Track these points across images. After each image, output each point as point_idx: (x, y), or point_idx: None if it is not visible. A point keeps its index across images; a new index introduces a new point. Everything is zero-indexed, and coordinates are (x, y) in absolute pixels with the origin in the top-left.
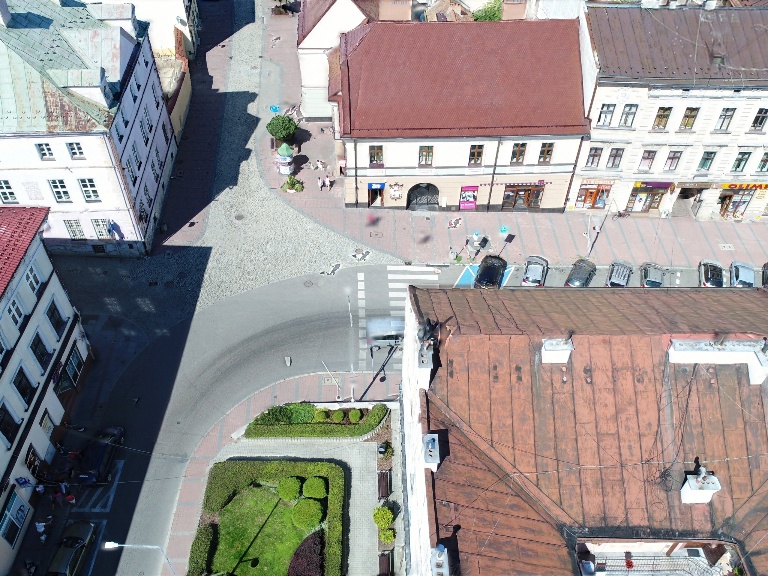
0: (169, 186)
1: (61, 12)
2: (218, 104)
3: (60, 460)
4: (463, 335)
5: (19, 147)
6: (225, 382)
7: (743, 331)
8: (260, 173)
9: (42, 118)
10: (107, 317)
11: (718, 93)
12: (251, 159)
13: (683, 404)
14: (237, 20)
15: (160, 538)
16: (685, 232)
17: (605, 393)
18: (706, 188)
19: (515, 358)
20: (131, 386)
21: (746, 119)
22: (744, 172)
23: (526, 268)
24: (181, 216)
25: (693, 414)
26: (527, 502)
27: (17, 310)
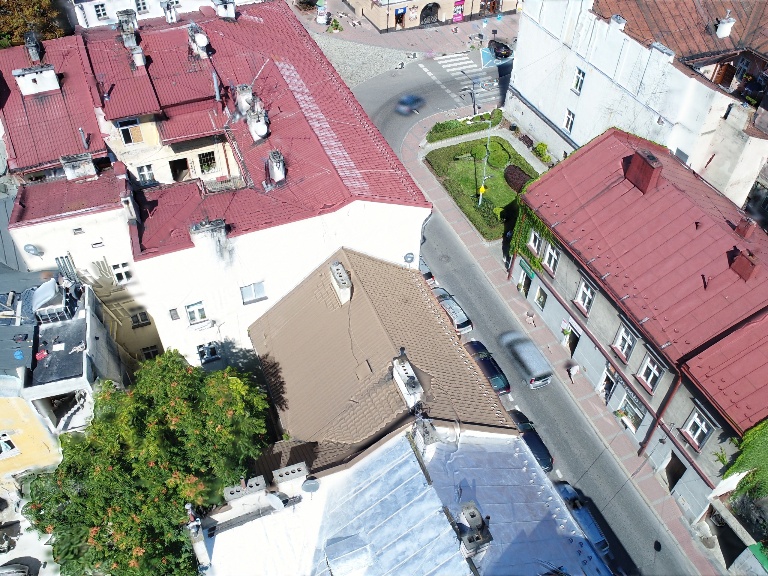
0: None
1: None
2: None
3: None
4: None
5: None
6: (388, 128)
7: None
8: None
9: None
10: None
11: None
12: None
13: None
14: None
15: None
16: None
17: None
18: None
19: None
20: None
21: None
22: None
23: None
24: None
25: None
26: None
27: None
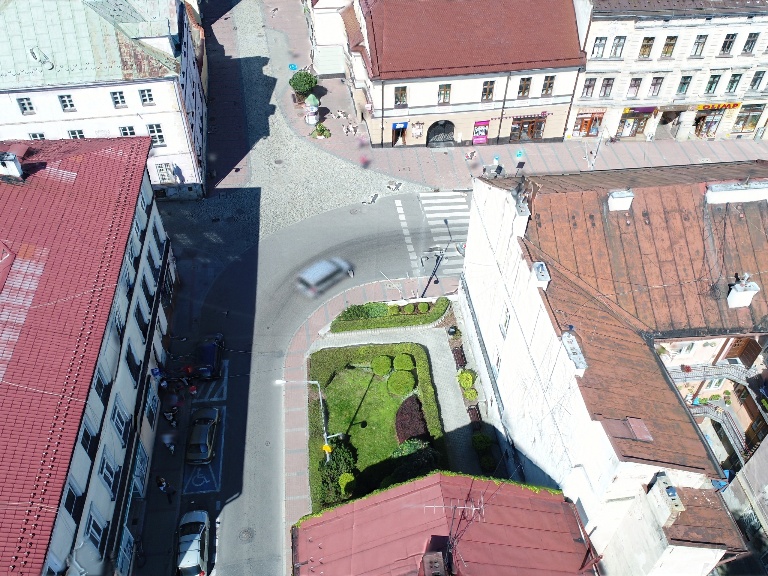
0: (208, 140)
1: None
2: (234, 68)
3: (172, 364)
4: (545, 194)
5: (96, 96)
6: (300, 294)
7: (759, 177)
8: (288, 124)
9: (118, 67)
10: (181, 249)
11: (693, 22)
12: (277, 113)
13: (721, 234)
14: None
15: (276, 415)
16: (668, 151)
17: (661, 231)
18: (684, 110)
19: (588, 209)
20: (218, 302)
21: (716, 44)
22: (715, 93)
23: None
24: (226, 164)
25: (730, 241)
26: (612, 316)
27: (136, 224)
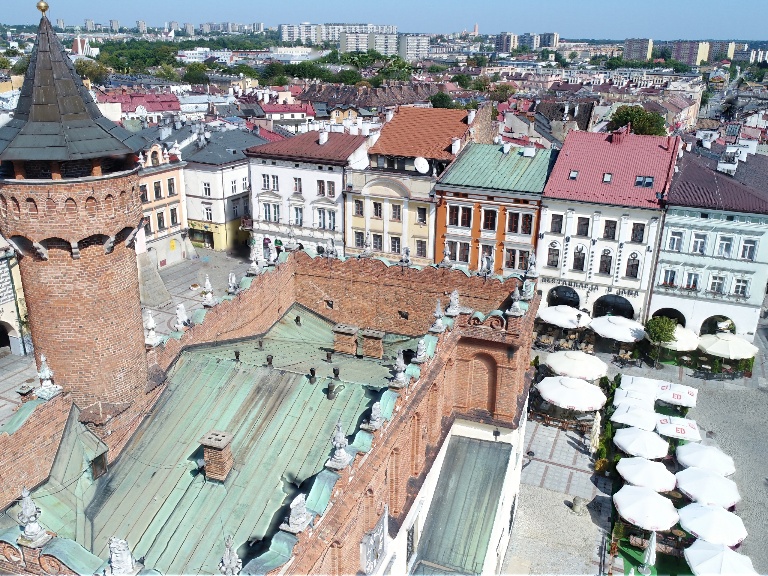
0: None
1: None
2: None
3: None
4: None
5: None
6: None
7: None
8: None
9: None
10: None
11: None
12: None
13: None
14: None
15: None
16: None
17: None
18: None
19: None
20: None
21: None
22: None
23: None
24: None
25: None
26: None
27: None
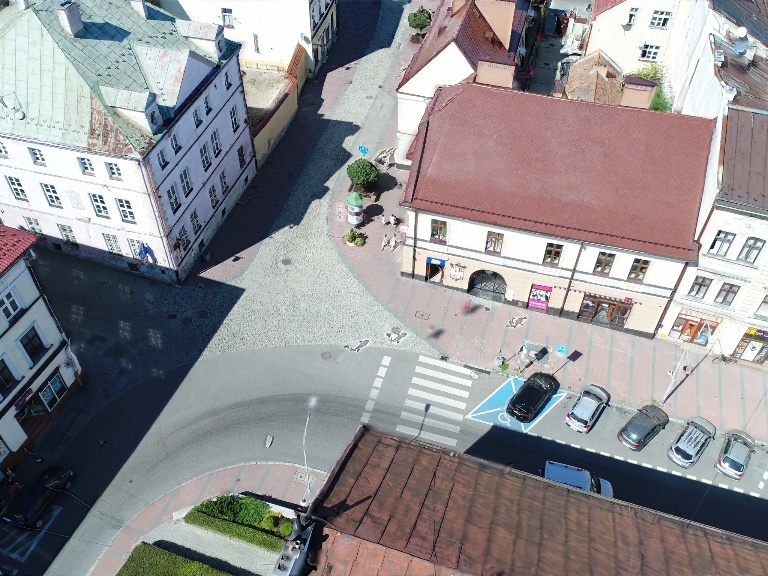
0: (232, 212)
1: (144, 25)
2: (317, 131)
3: (5, 488)
4: (355, 537)
5: (63, 157)
6: (195, 447)
7: None
8: (328, 216)
9: (85, 134)
10: (114, 342)
11: None
12: (325, 199)
13: None
14: (373, 42)
15: None
16: None
17: None
18: None
19: None
20: (104, 425)
21: None
22: None
23: (577, 400)
24: (230, 247)
25: None
26: None
27: None
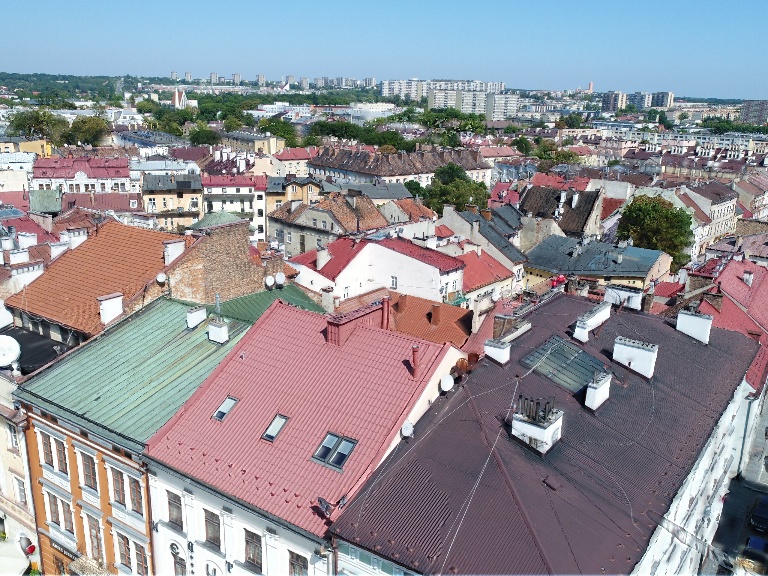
0: None
1: None
2: None
3: None
4: None
5: None
6: None
7: None
8: None
9: None
10: None
11: None
12: None
13: None
14: None
15: None
16: None
17: None
18: None
19: None
20: None
21: None
22: None
23: None
24: None
25: None
26: None
27: None
